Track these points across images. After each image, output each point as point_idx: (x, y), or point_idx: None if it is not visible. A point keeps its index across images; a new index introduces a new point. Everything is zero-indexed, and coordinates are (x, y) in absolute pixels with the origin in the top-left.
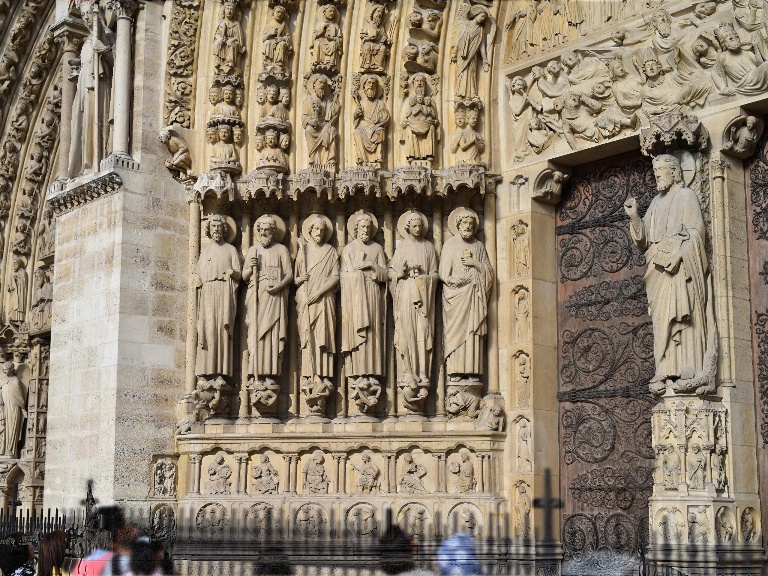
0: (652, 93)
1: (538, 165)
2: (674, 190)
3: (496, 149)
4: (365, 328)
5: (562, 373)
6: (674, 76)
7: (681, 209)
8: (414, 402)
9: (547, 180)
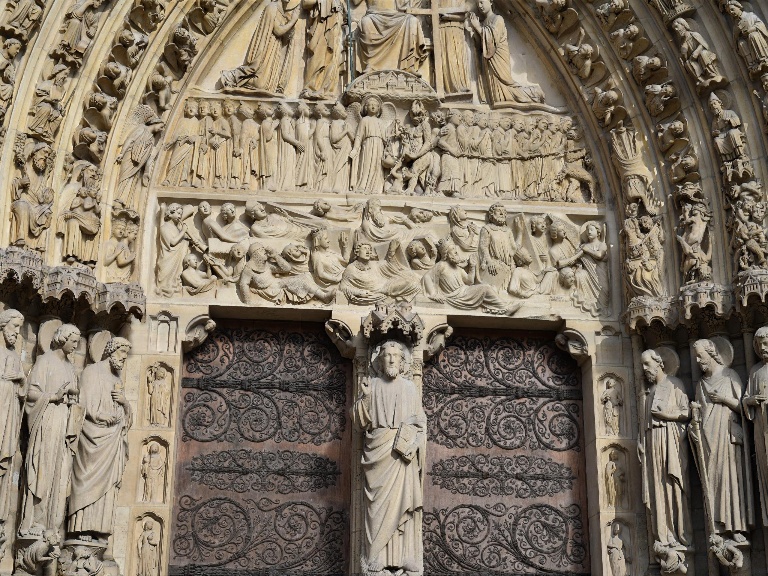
0: (360, 275)
1: (195, 307)
2: (400, 379)
3: (139, 274)
4: (9, 457)
5: (175, 544)
6: (382, 266)
7: (411, 400)
8: (41, 562)
9: (198, 326)
